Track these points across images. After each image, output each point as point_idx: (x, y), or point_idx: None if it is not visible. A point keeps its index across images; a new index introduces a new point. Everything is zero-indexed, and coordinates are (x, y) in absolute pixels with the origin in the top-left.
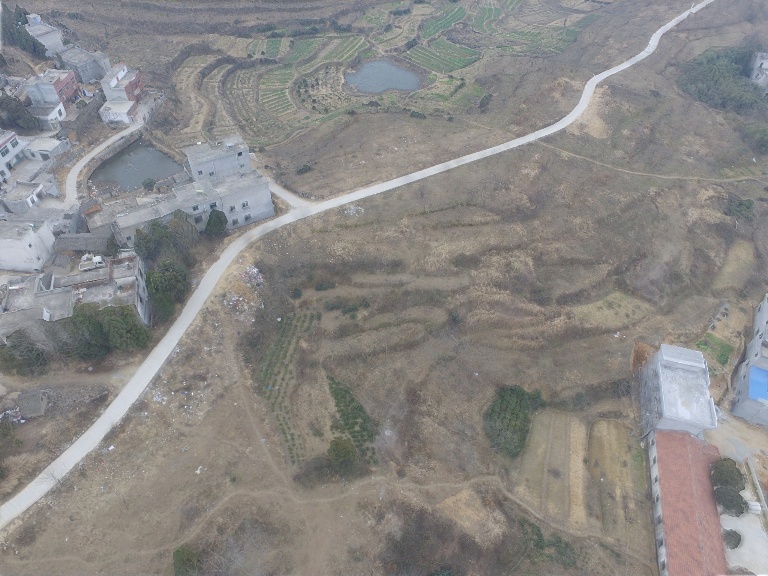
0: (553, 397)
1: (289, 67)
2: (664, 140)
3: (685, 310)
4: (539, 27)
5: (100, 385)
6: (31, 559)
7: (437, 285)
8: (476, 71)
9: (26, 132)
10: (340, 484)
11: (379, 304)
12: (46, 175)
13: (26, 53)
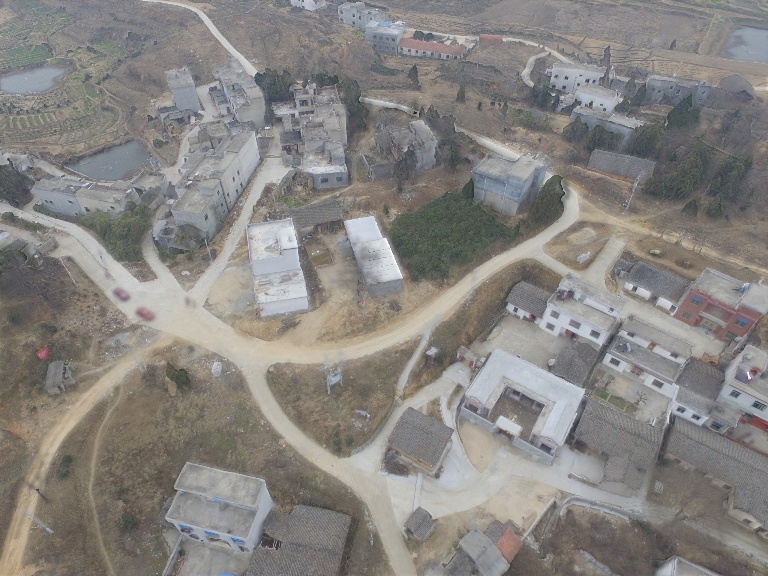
0: (378, 61)
1: None
2: (222, 2)
3: (339, 30)
4: (0, 25)
5: (376, 113)
6: (462, 121)
7: None
8: (71, 42)
9: (28, 197)
10: (422, 88)
11: (324, 72)
12: (117, 183)
13: None
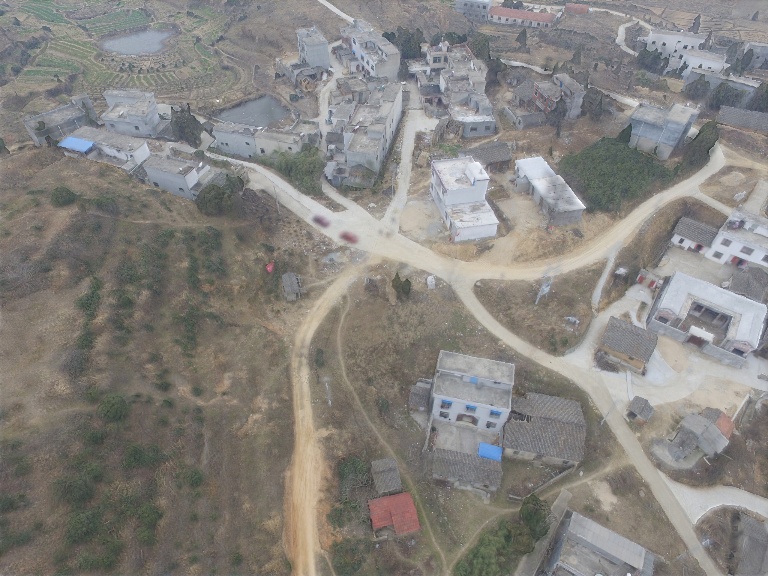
0: (472, 28)
1: (86, 74)
2: None
3: None
4: None
5: None
6: None
7: (422, 21)
8: (169, 8)
9: None
10: None
11: None
12: None
13: (3, 154)
